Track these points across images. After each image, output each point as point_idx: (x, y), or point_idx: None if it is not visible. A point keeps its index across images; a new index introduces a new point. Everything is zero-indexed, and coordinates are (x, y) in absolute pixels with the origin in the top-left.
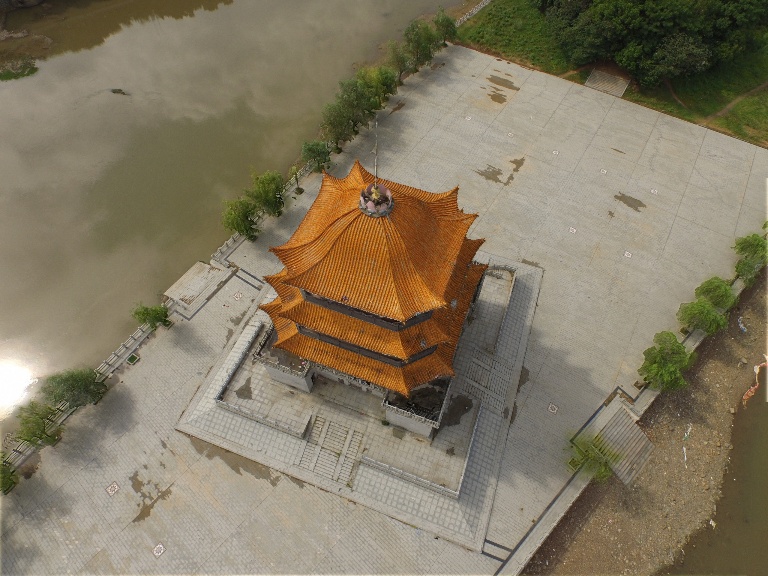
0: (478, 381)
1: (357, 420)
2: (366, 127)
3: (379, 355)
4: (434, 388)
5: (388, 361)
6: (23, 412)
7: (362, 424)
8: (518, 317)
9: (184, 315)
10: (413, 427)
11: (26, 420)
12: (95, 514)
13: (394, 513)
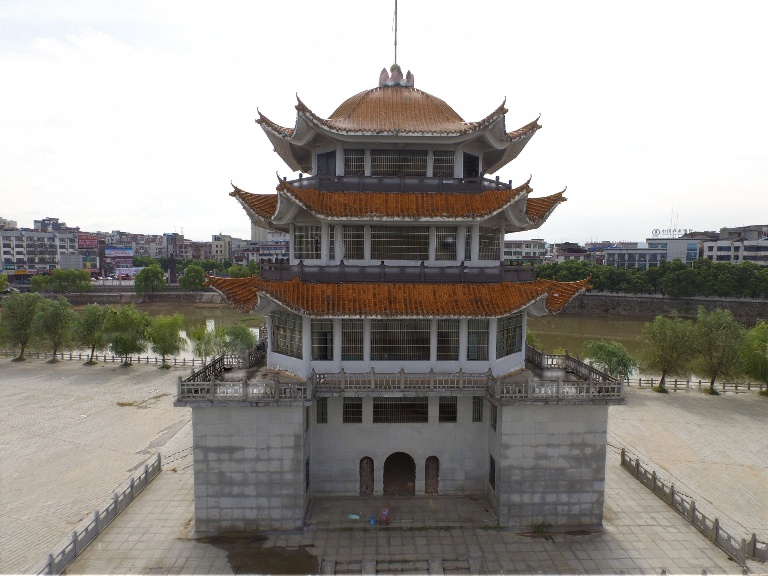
0: None
1: None
2: (724, 377)
3: (269, 262)
4: None
5: None
6: (216, 331)
7: None
8: None
9: None
10: None
11: (211, 336)
12: (131, 391)
13: (36, 568)
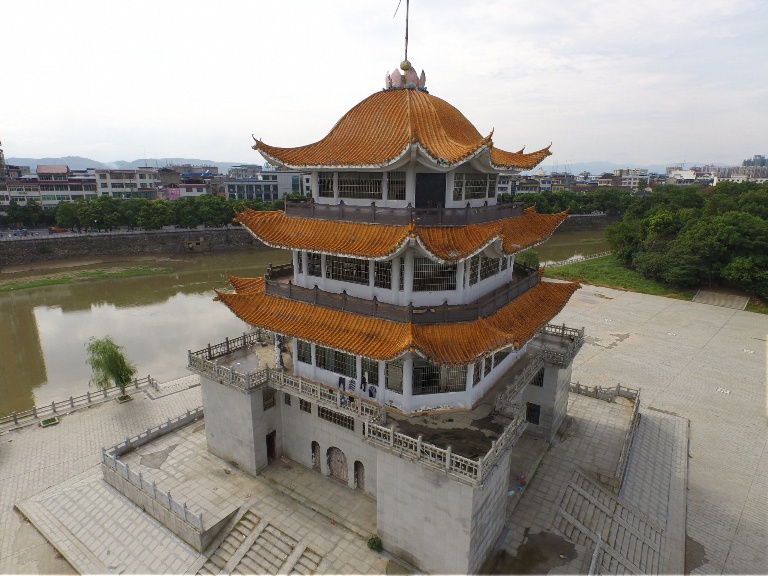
0: (586, 524)
1: (320, 531)
2: None
3: (375, 299)
4: (481, 431)
5: (390, 314)
6: None
7: (327, 539)
8: (656, 461)
9: (151, 395)
10: (431, 543)
11: None
12: None
13: None
